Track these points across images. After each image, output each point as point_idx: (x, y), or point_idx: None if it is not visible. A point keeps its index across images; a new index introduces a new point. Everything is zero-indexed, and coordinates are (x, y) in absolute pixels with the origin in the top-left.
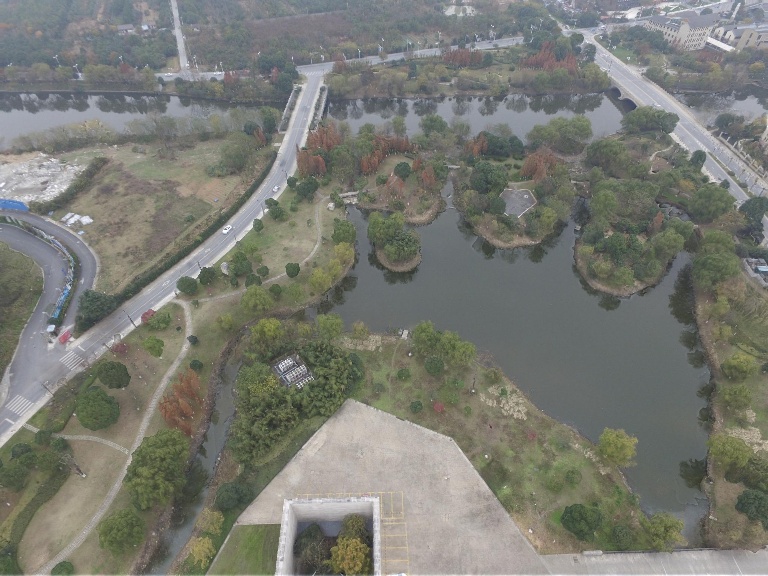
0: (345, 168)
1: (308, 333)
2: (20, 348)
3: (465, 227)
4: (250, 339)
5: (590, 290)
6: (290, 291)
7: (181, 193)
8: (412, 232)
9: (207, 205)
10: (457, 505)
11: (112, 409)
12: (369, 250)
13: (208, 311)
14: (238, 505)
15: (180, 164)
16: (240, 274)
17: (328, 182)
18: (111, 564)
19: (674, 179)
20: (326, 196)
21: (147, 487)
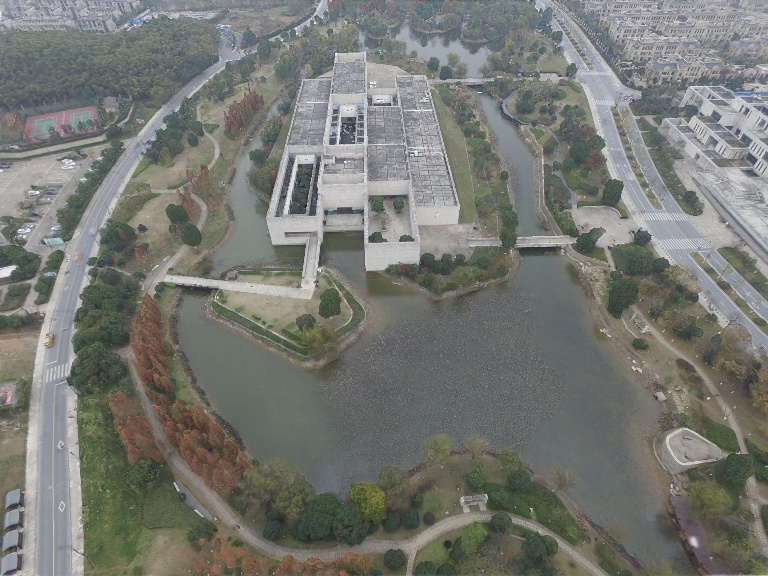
0: (352, 7)
1: (339, 43)
2: (220, 52)
3: (412, 34)
4: (316, 40)
5: (466, 47)
6: (330, 35)
7: (271, 19)
8: (384, 23)
9: (285, 23)
10: (394, 74)
11: (269, 51)
12: (364, 39)
13: (295, 45)
14: (317, 74)
15: (266, 13)
16: (307, 34)
17: (344, 16)
18: (277, 83)
19: (514, 7)
20: (343, 20)
21: (288, 59)
